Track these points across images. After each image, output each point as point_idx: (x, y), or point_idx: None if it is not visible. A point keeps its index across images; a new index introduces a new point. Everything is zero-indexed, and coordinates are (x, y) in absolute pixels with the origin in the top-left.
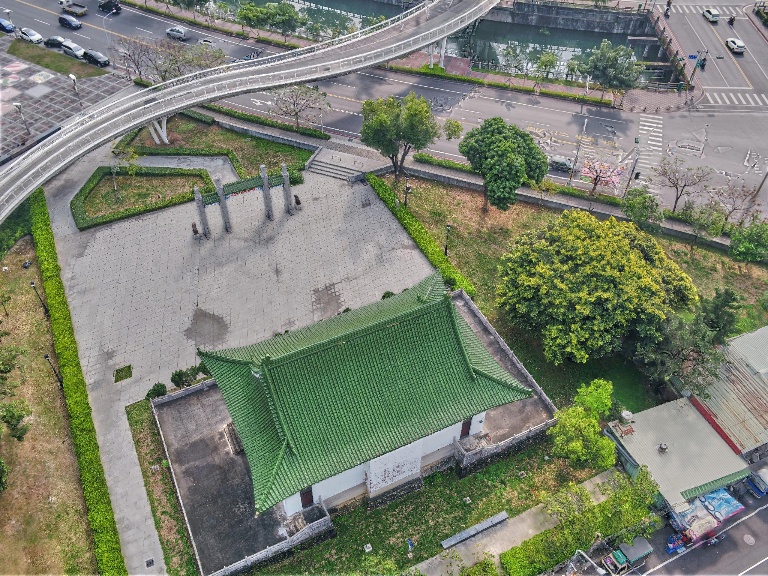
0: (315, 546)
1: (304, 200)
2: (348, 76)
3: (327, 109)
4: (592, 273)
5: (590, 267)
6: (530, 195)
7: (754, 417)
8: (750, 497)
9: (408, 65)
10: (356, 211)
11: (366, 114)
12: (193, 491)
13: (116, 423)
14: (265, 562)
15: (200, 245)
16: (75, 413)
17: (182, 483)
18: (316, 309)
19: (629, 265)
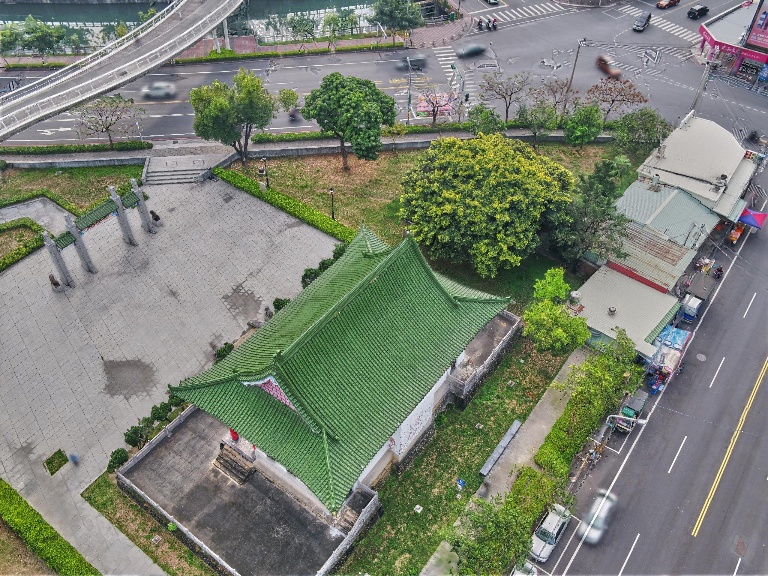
0: (369, 532)
1: (160, 215)
2: (135, 81)
3: (141, 115)
4: (495, 183)
5: (492, 178)
6: None
7: (661, 260)
8: (685, 324)
9: (193, 56)
10: (221, 208)
11: (196, 105)
12: (218, 539)
13: (80, 515)
14: (333, 569)
15: (68, 297)
16: (24, 526)
17: (201, 538)
18: (236, 314)
19: (522, 166)
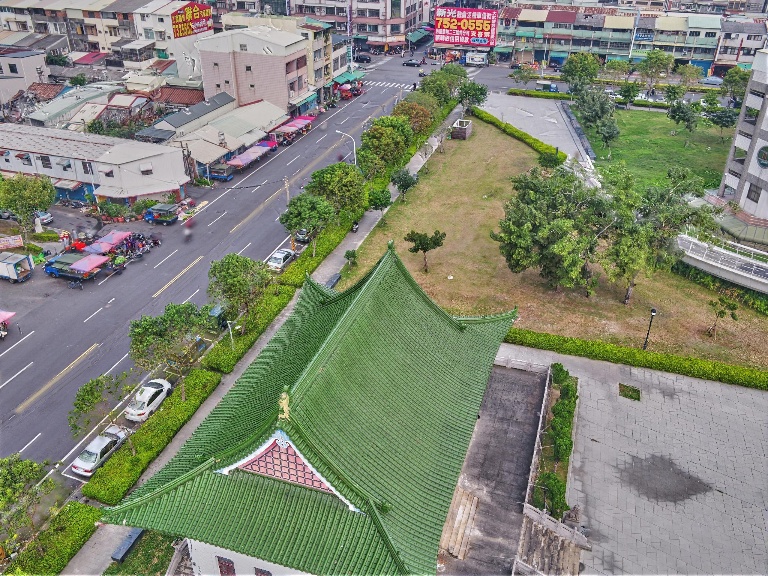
0: None
1: None
2: None
3: None
4: None
5: None
6: None
7: None
8: None
9: None
10: None
11: None
12: None
13: None
14: None
15: None
16: (590, 343)
17: None
18: None
19: None
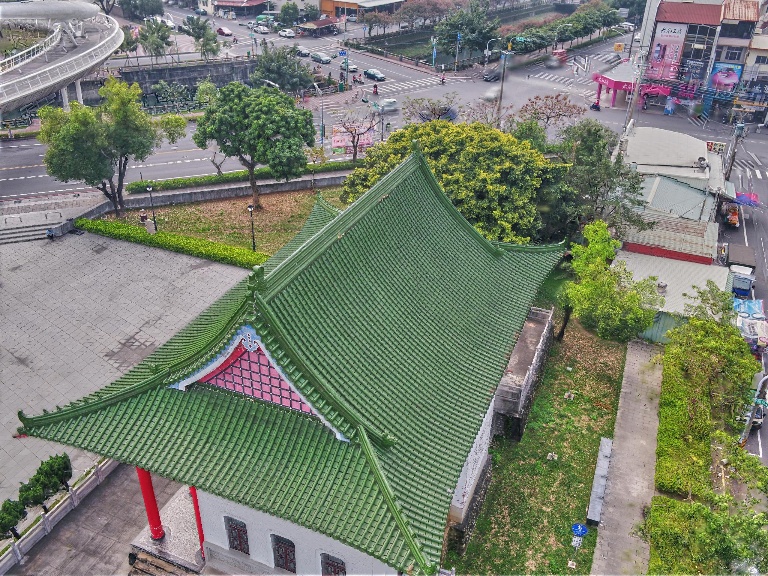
0: None
1: None
2: None
3: None
4: (474, 154)
5: (470, 148)
6: (295, 180)
7: (685, 234)
8: None
9: None
10: (91, 260)
11: (47, 130)
12: None
13: None
14: None
15: None
16: None
17: None
18: None
19: (500, 136)
